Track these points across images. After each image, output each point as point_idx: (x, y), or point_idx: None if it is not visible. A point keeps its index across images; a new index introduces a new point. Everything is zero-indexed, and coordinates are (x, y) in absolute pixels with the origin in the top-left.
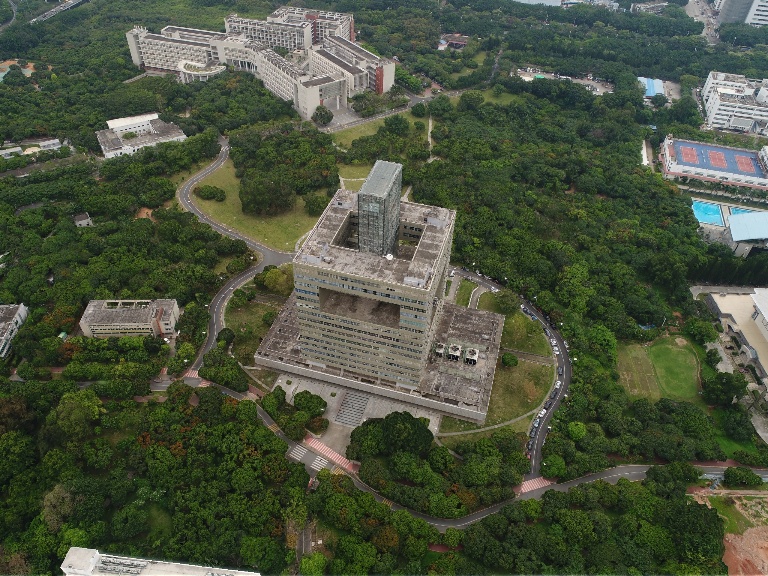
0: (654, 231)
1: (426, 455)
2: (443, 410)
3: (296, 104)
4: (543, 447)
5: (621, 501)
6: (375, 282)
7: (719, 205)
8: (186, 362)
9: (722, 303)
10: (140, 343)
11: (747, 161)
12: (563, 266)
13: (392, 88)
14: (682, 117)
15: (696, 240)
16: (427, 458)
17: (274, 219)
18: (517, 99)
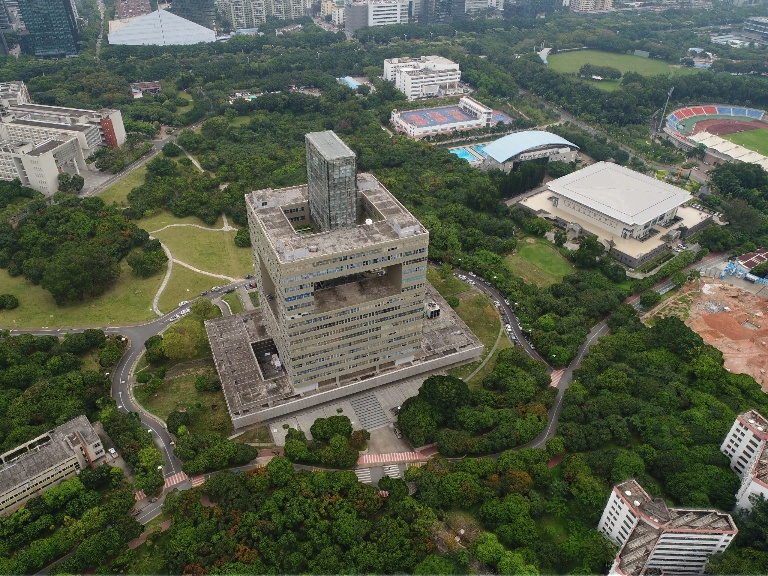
0: (449, 175)
1: (471, 404)
2: (445, 365)
3: (24, 182)
4: (539, 347)
5: (618, 350)
6: (376, 247)
7: (463, 148)
8: (159, 470)
9: (530, 205)
10: (78, 485)
11: (457, 113)
12: None
13: (128, 137)
14: (389, 97)
15: (477, 172)
16: (476, 405)
17: (103, 298)
18: (256, 116)
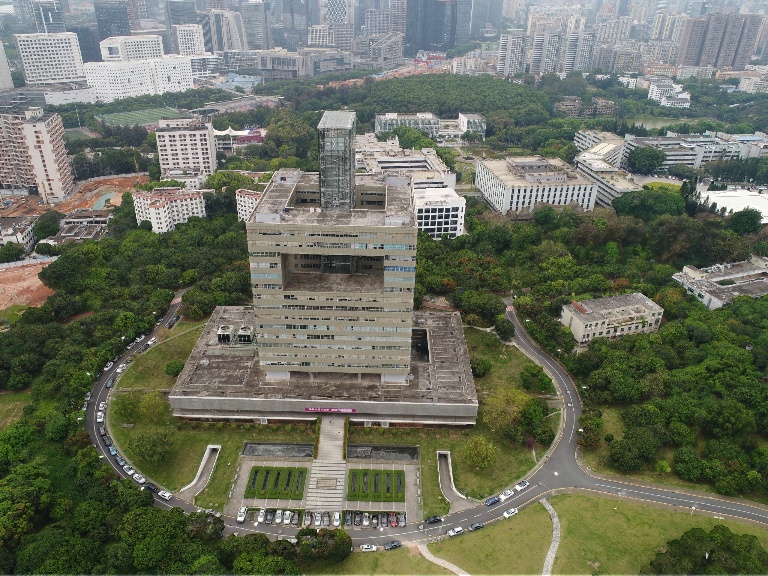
0: None
1: None
2: None
3: None
4: None
5: None
6: None
7: None
8: None
9: None
10: None
11: None
12: (2, 543)
13: None
14: None
15: None
16: None
17: None
18: None
